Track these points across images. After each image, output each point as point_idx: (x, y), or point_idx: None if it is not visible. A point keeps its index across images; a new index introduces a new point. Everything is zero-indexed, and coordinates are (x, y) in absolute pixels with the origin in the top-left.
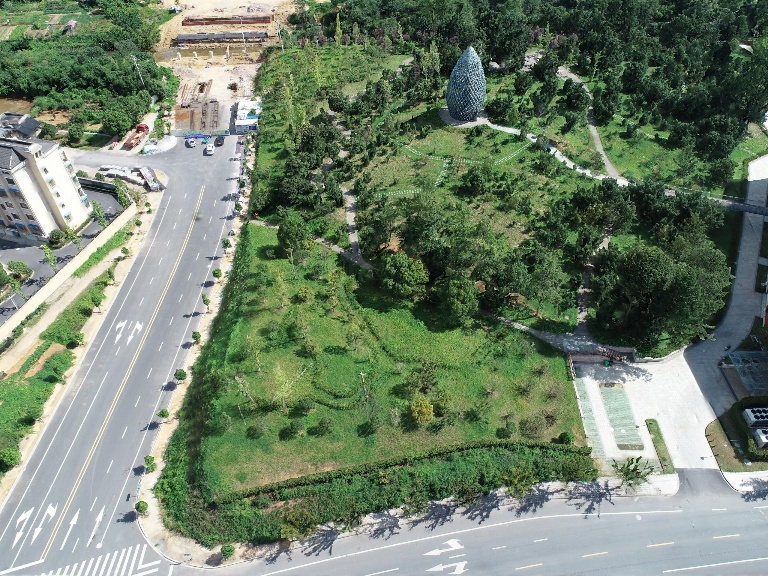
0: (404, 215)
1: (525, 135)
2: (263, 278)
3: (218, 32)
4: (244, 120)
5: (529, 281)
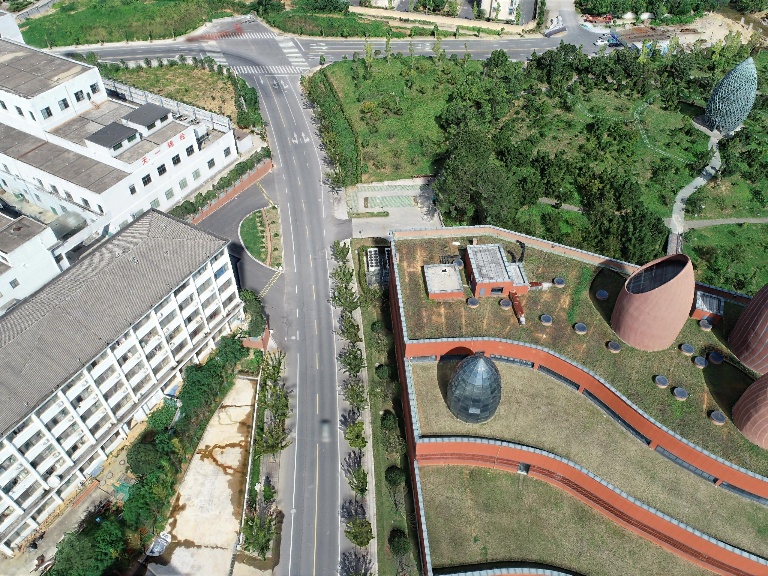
0: None
1: (705, 156)
2: (454, 55)
3: None
4: None
5: None
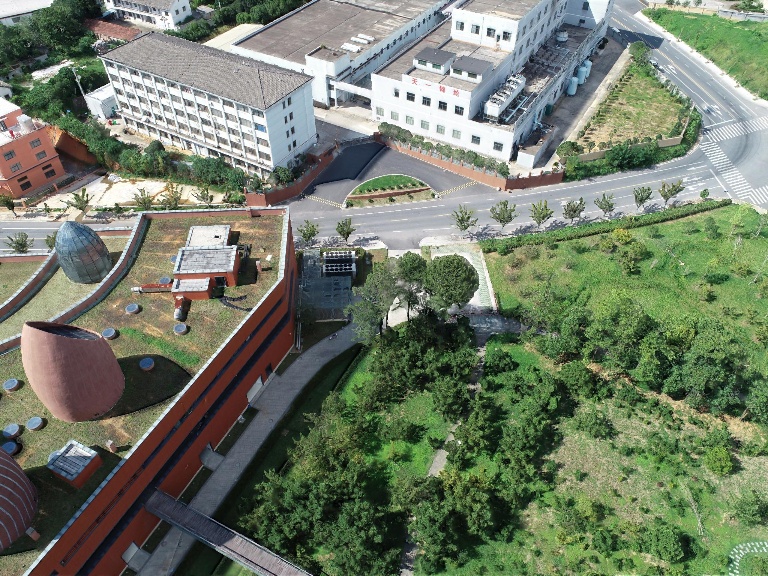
0: None
1: None
2: None
3: None
4: None
5: (554, 339)
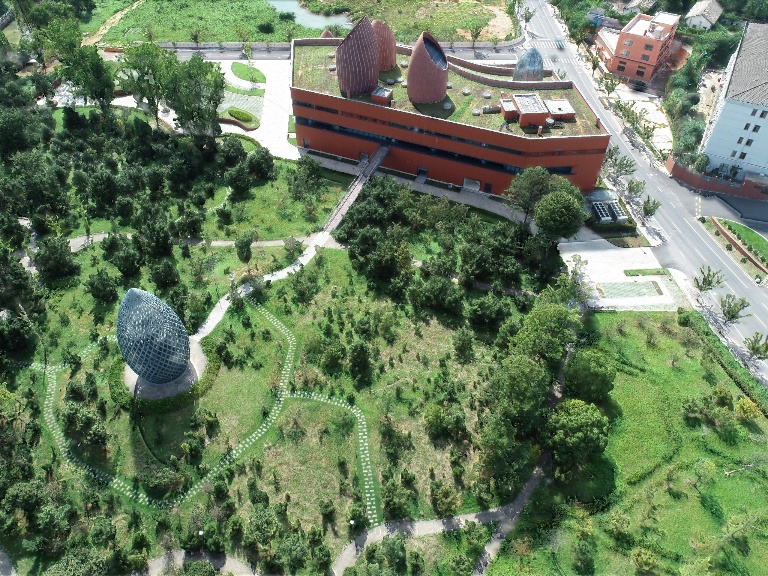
0: (531, 401)
1: None
2: None
3: None
4: None
5: None
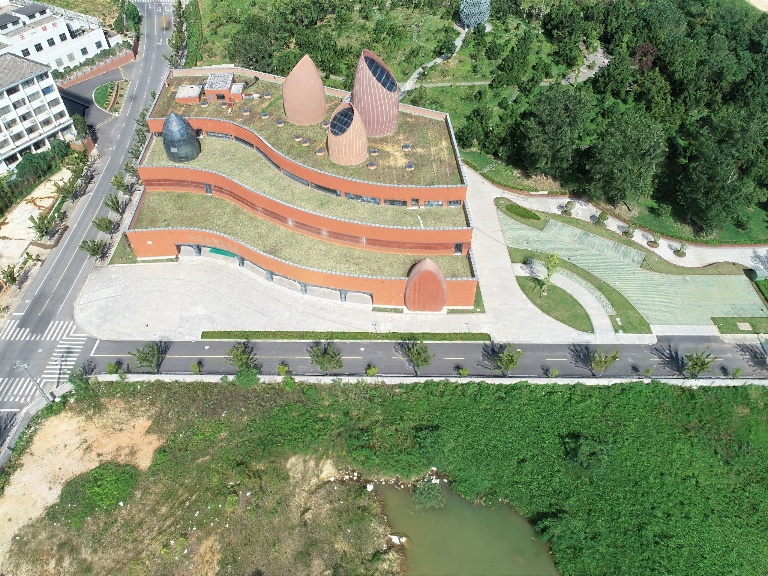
0: None
1: None
2: None
3: None
4: None
5: None
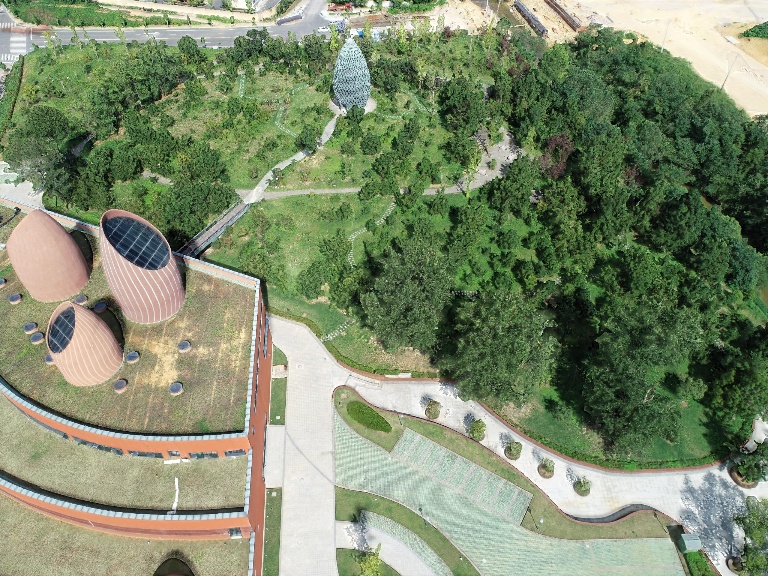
0: None
1: None
2: (148, 41)
3: (543, 15)
4: (356, 31)
5: None
